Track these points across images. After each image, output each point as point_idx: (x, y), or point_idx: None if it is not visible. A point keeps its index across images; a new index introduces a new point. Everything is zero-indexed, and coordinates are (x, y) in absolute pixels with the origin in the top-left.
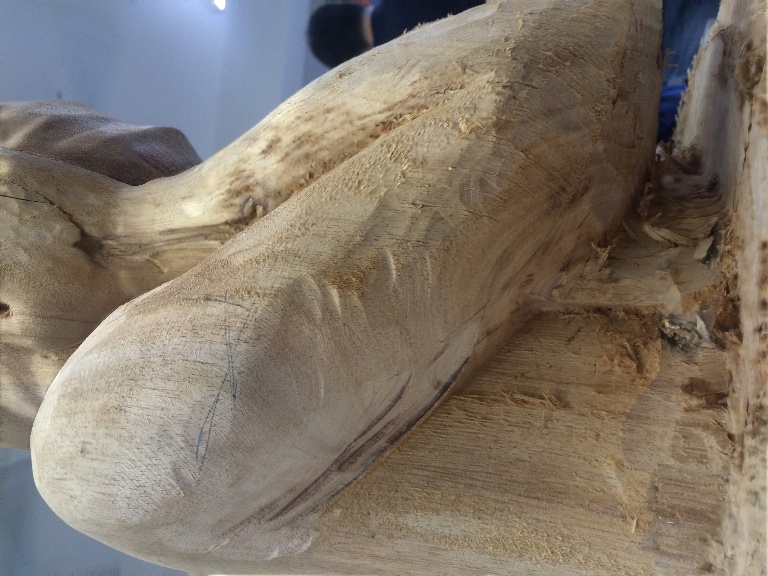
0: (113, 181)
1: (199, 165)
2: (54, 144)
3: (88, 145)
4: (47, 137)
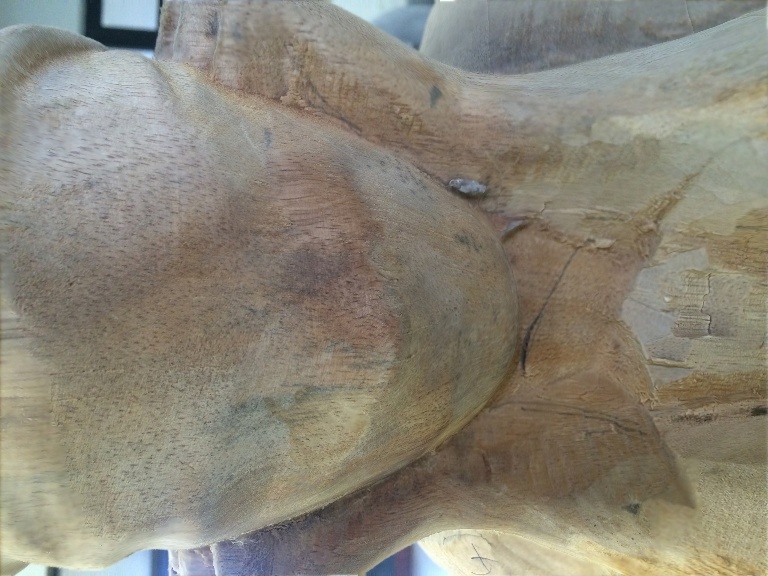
0: (418, 527)
1: (574, 544)
2: (254, 520)
3: (313, 499)
4: (234, 526)
